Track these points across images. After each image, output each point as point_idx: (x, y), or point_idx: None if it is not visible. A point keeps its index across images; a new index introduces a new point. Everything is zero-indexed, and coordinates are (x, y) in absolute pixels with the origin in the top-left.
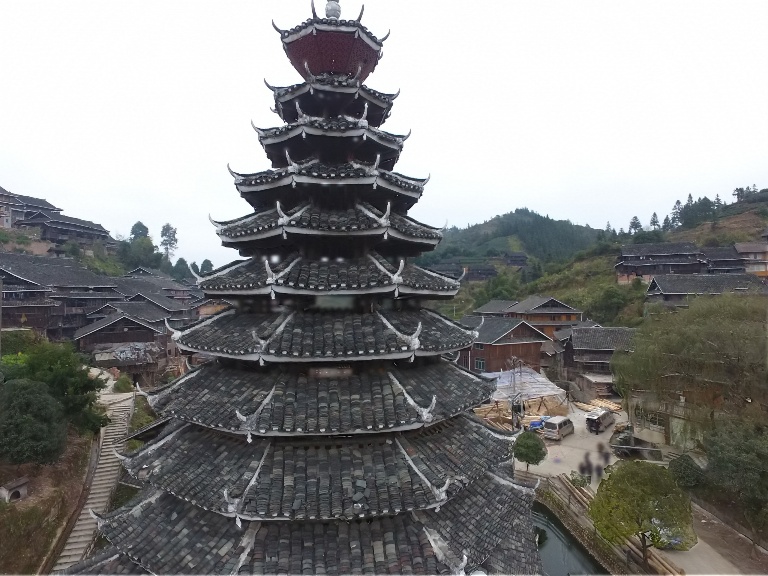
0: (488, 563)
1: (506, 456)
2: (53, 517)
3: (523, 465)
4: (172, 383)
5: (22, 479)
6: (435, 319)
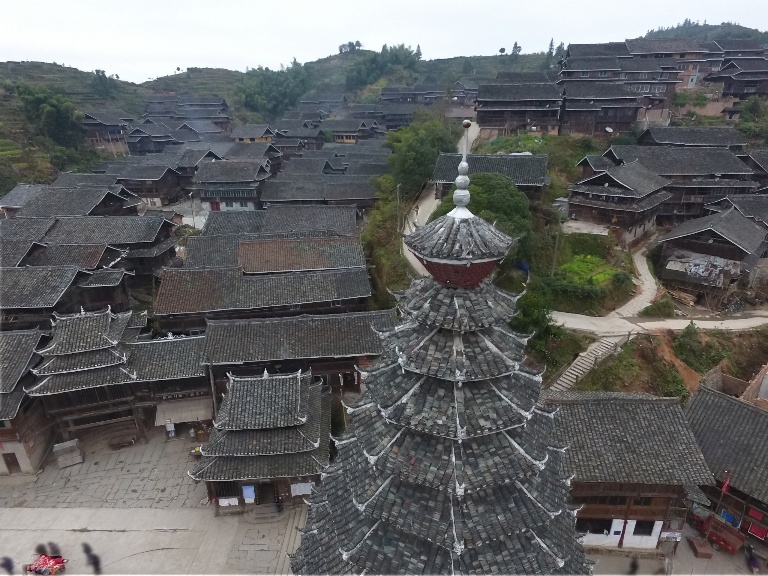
0: None
1: None
2: None
3: None
4: None
5: None
6: (445, 551)
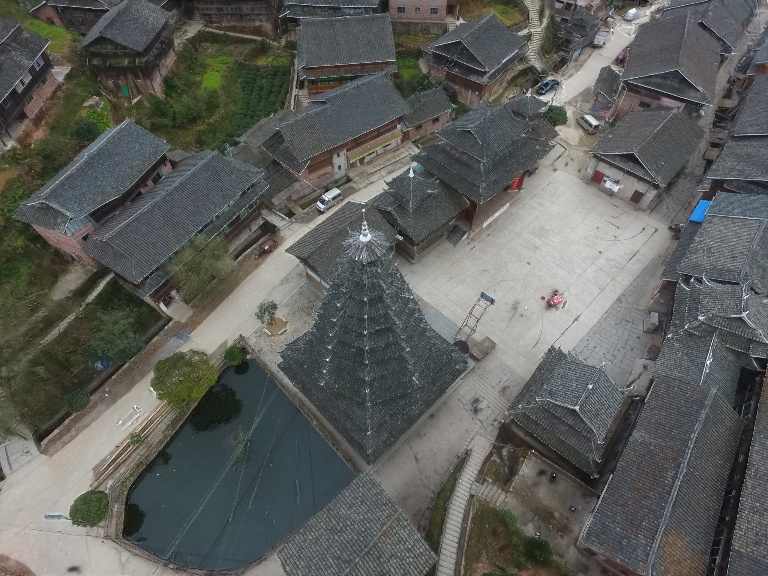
0: None
1: (52, 575)
2: None
3: (72, 541)
4: (423, 323)
5: None
6: None
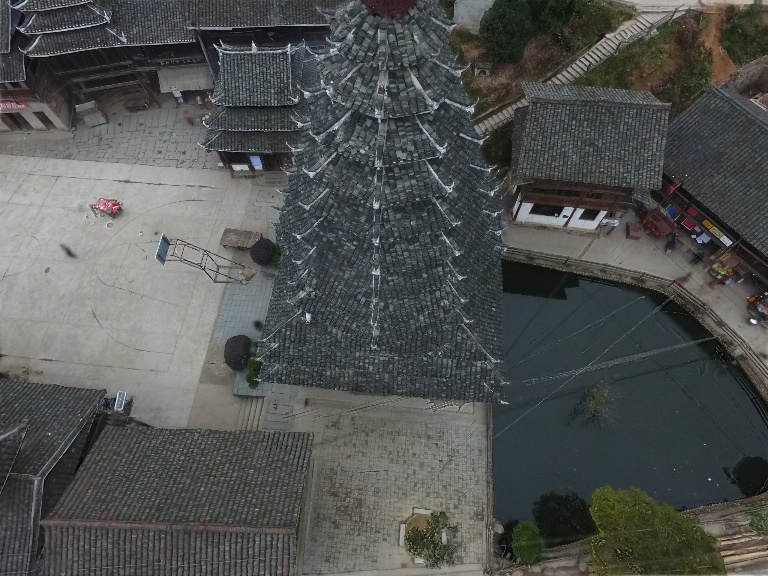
0: None
1: None
2: (492, 99)
3: None
4: None
5: (488, 65)
6: None
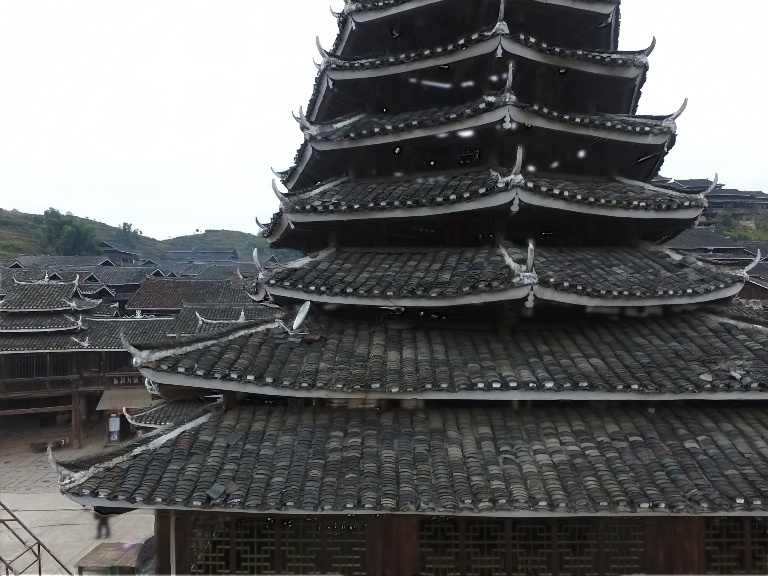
0: (403, 346)
1: None
2: None
3: None
4: None
5: None
6: None
